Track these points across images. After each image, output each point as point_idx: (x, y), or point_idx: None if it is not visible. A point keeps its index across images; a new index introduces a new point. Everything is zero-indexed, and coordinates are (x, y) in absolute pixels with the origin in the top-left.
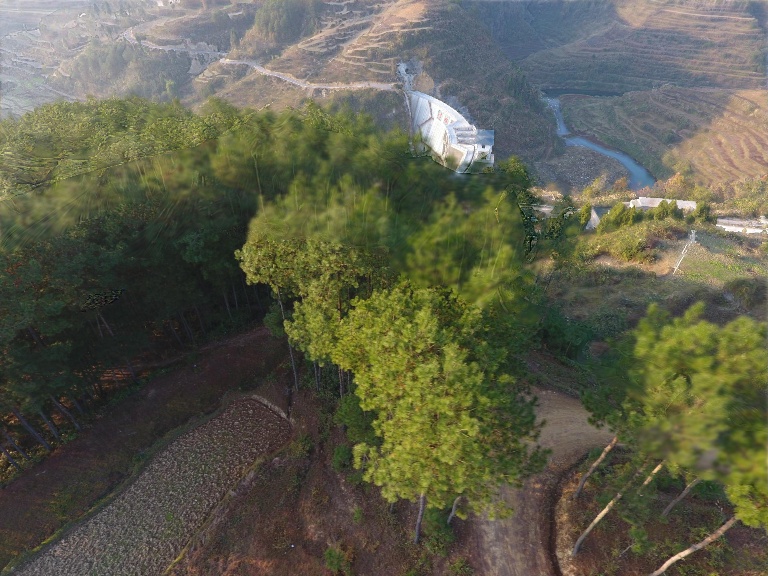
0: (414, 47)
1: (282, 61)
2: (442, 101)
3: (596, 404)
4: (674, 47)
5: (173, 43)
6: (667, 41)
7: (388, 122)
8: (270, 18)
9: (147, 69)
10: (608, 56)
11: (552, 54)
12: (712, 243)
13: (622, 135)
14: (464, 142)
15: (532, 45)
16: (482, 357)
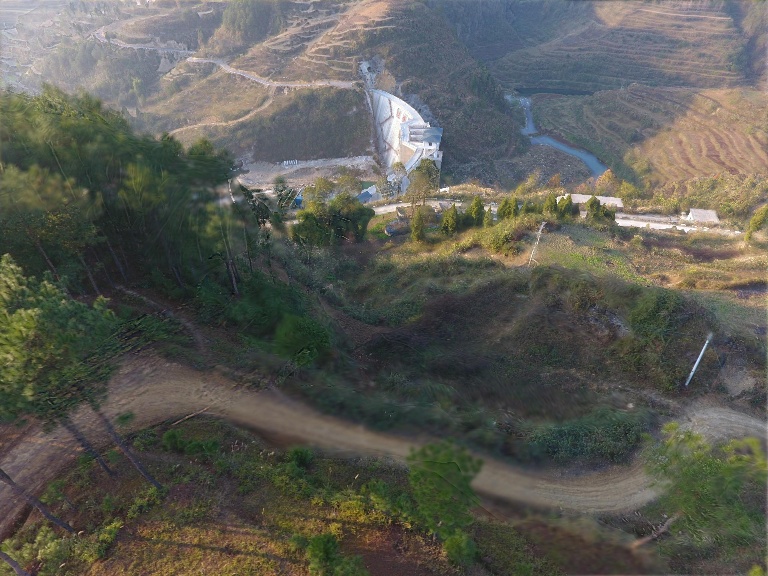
0: (376, 45)
1: (247, 59)
2: (404, 99)
3: (217, 376)
4: (649, 46)
5: (142, 41)
6: (642, 40)
7: (348, 120)
8: (237, 17)
9: (115, 67)
10: (582, 55)
11: (527, 53)
12: (584, 236)
13: (588, 134)
14: (415, 140)
15: (511, 45)
16: (148, 333)
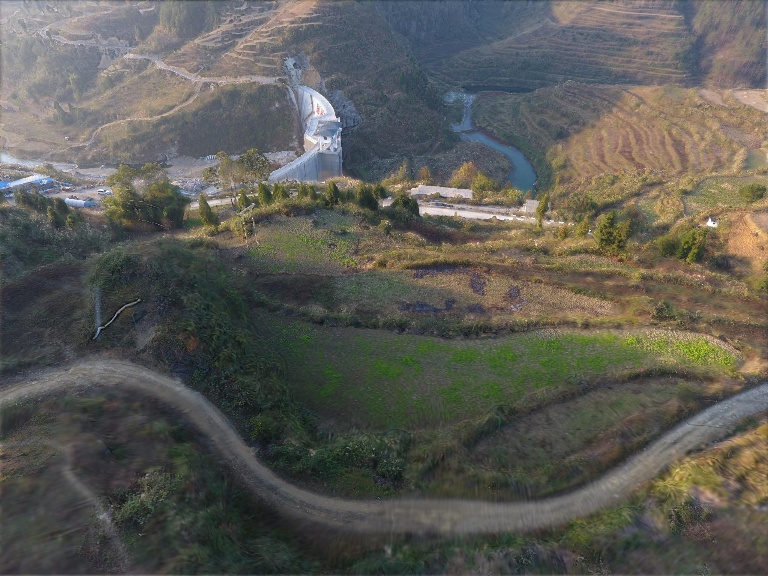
0: (302, 42)
1: (178, 55)
2: (328, 95)
3: None
4: (598, 44)
5: (83, 38)
6: (592, 38)
7: (271, 115)
8: (172, 13)
9: (55, 63)
10: (531, 53)
11: (478, 51)
12: (334, 220)
13: (520, 131)
14: None
15: (469, 43)
16: None
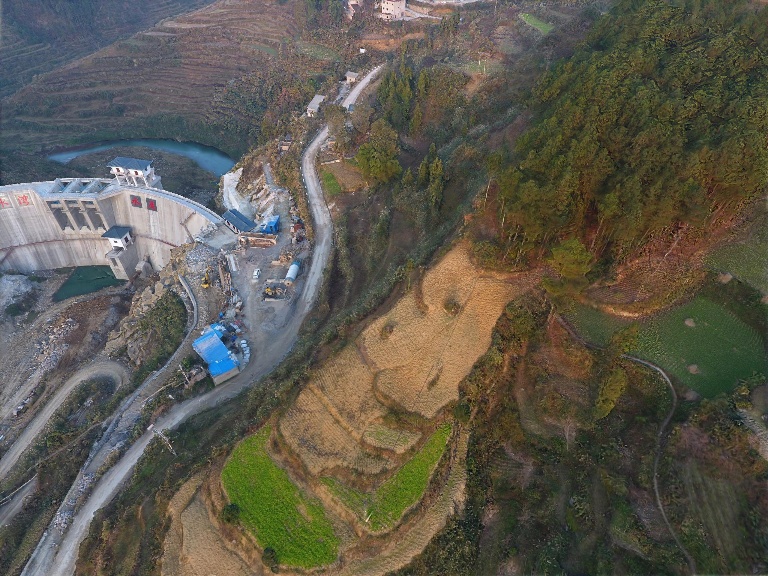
0: None
1: None
2: None
3: None
4: None
5: None
6: None
7: None
8: None
9: None
10: None
11: None
12: None
13: (75, 132)
14: (101, 188)
15: None
16: None
